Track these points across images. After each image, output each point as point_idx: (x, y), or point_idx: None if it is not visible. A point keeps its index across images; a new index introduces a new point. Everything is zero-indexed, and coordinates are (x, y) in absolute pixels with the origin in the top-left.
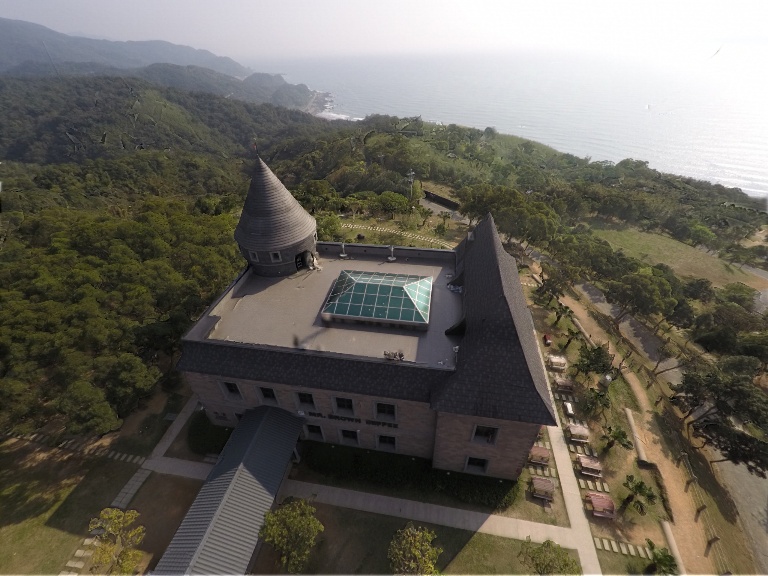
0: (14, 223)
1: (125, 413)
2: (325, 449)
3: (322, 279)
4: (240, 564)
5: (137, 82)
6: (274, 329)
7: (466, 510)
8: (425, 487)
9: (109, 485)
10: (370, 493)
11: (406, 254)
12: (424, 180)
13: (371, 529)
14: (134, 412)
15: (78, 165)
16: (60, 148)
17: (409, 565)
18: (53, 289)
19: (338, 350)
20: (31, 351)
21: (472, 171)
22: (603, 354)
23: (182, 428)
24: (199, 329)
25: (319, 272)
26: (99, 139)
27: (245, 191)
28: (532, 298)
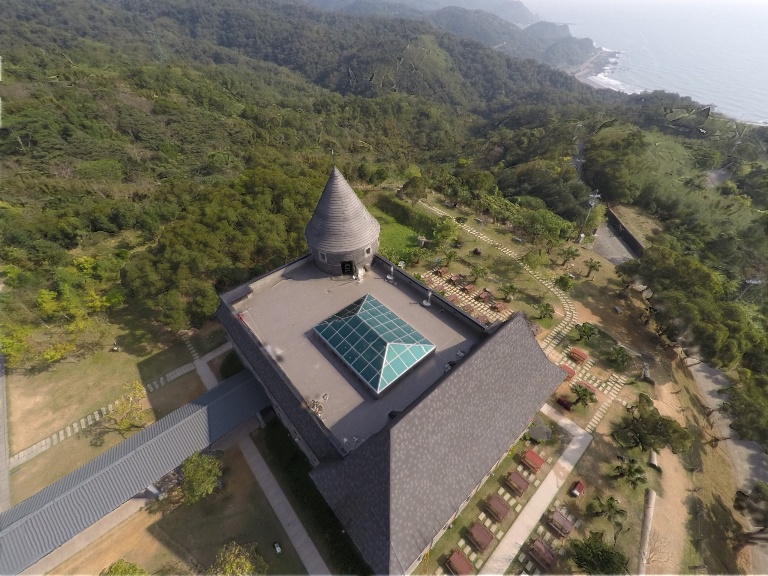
0: (285, 137)
1: (197, 322)
2: (282, 432)
3: (351, 293)
4: (160, 471)
5: (415, 28)
6: (279, 320)
7: (331, 574)
8: (317, 525)
9: (173, 362)
10: (283, 492)
11: (444, 305)
12: (627, 204)
13: (261, 519)
14: (214, 321)
15: (343, 98)
16: (341, 81)
17: (217, 572)
18: (206, 217)
19: (298, 368)
20: (172, 256)
21: (712, 213)
22: (614, 565)
23: (228, 350)
24: (233, 293)
25: (357, 284)
26: (369, 77)
27: (425, 161)
28: (615, 426)
